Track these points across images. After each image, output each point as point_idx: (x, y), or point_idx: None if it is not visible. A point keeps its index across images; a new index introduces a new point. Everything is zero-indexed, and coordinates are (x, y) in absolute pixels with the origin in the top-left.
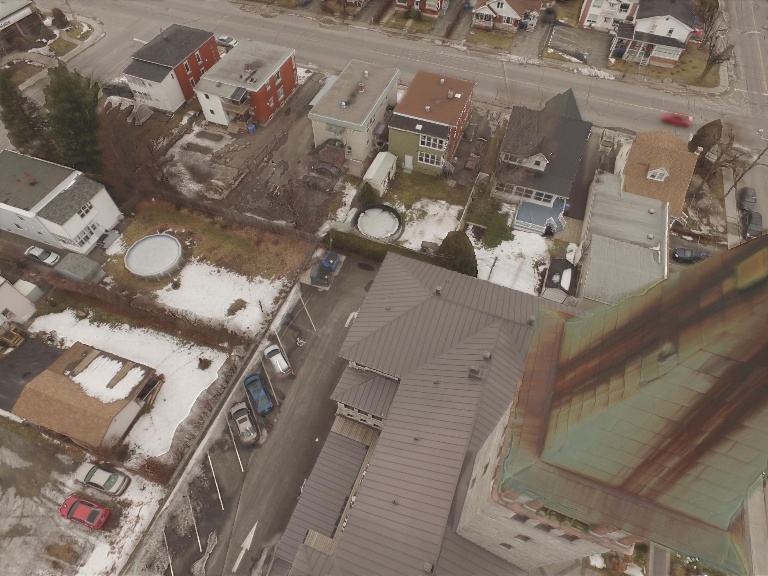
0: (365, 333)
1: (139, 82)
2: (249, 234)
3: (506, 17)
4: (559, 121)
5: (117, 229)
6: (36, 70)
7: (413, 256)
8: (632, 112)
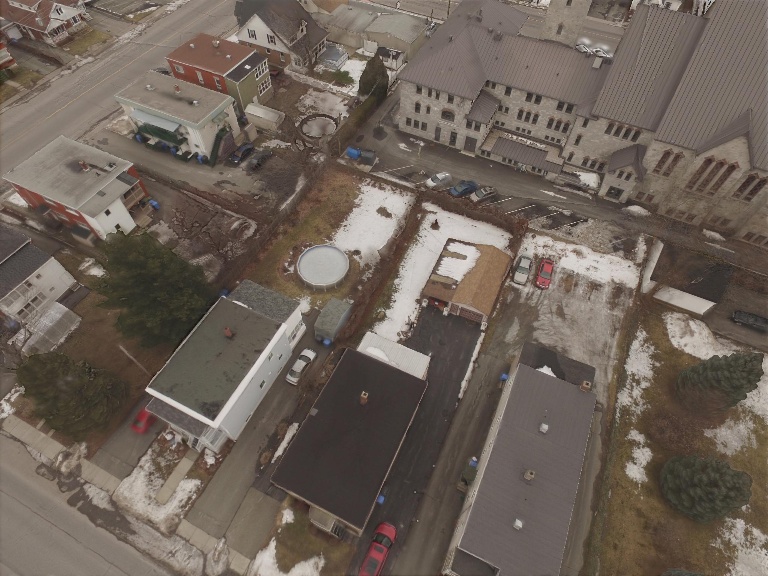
0: (464, 82)
1: (22, 291)
2: (306, 207)
3: (71, 18)
4: (278, 2)
5: None
6: None
7: (364, 105)
8: (234, 2)
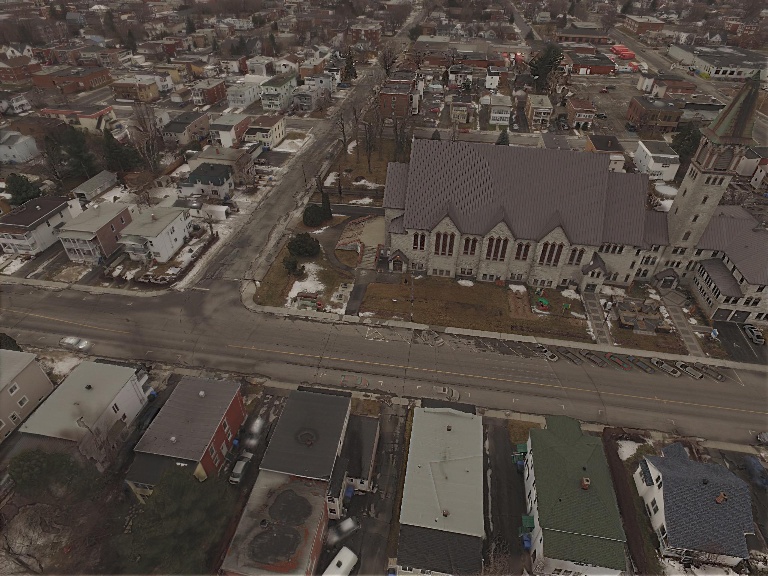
0: None
1: None
2: None
3: None
4: None
5: (666, 182)
6: None
7: None
8: None
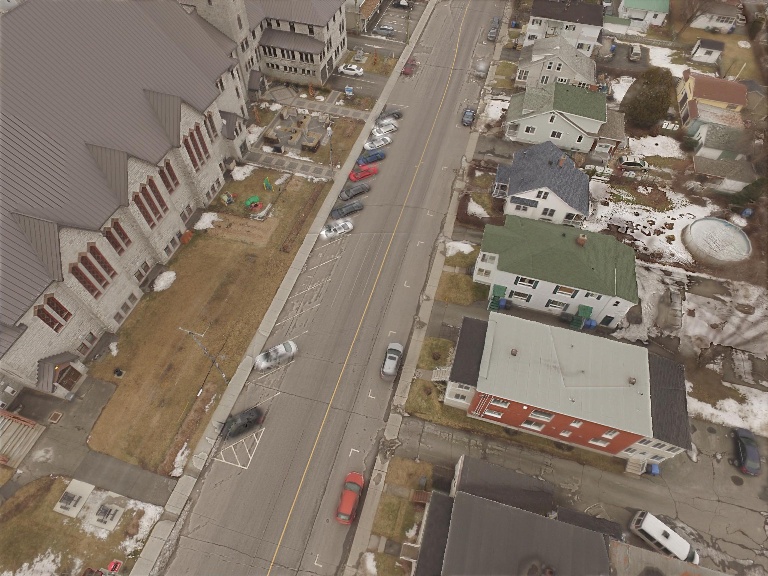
0: None
1: None
2: None
3: None
4: None
5: None
6: None
7: None
8: None
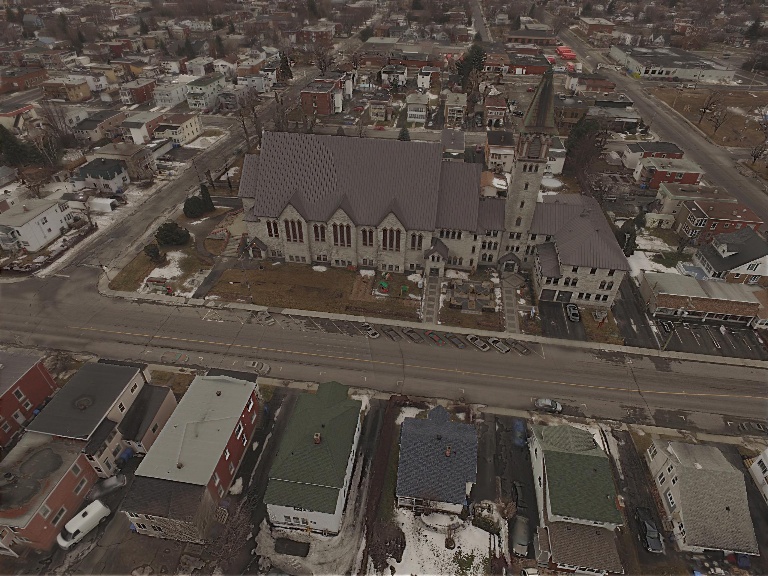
0: None
1: (628, 151)
2: None
3: None
4: (760, 242)
5: (554, 175)
6: (610, 138)
7: (615, 231)
8: None
